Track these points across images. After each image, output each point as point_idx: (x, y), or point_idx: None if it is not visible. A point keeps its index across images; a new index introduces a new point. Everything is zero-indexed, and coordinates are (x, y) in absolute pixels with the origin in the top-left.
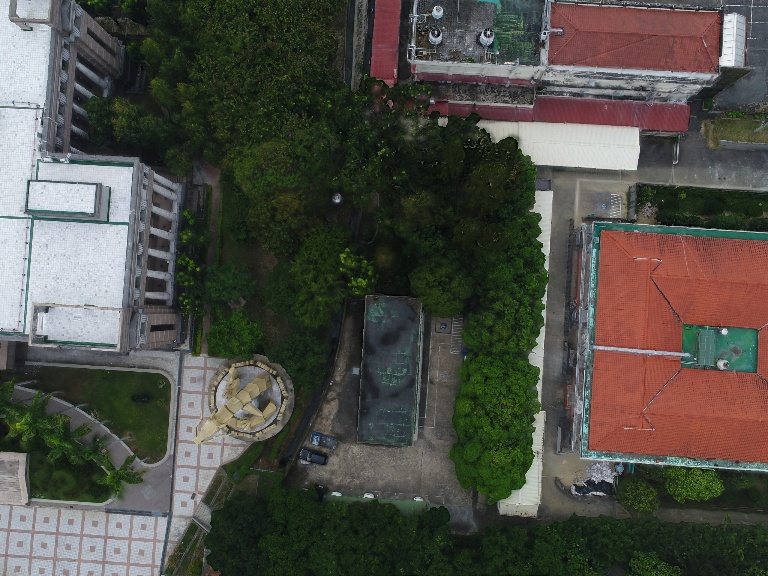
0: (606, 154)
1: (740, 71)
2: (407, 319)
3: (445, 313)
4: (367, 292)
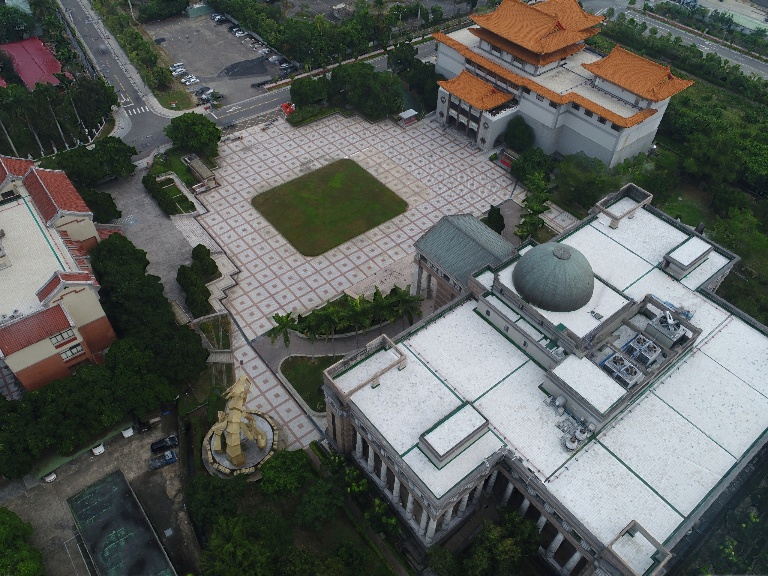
0: None
1: None
2: None
3: None
4: None
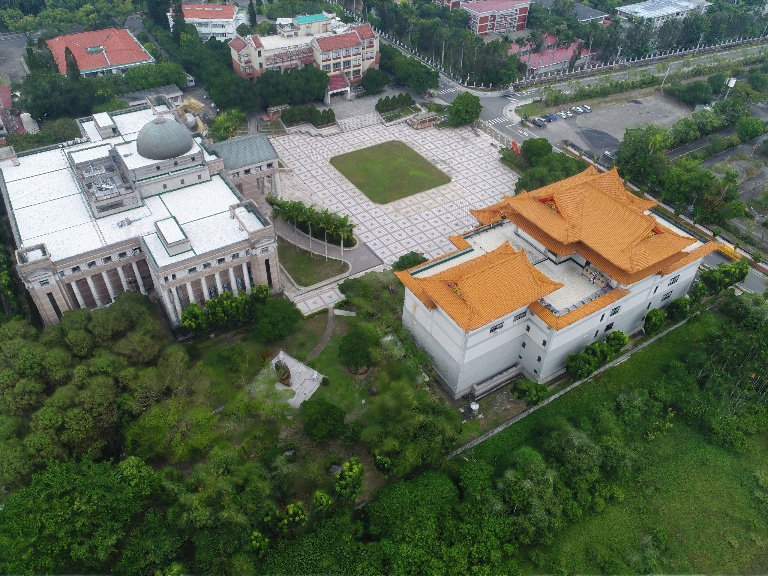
0: None
1: None
2: None
3: None
4: None
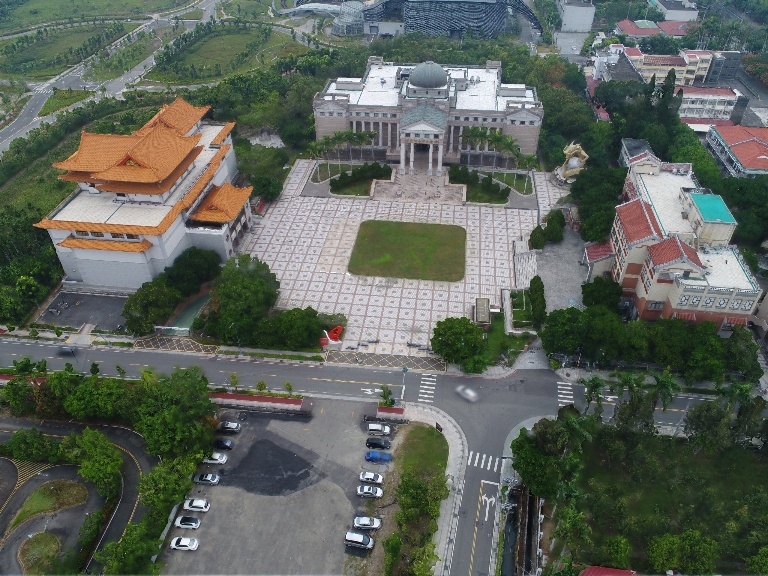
0: (704, 127)
1: (746, 100)
2: (642, 144)
3: (658, 145)
4: (622, 136)
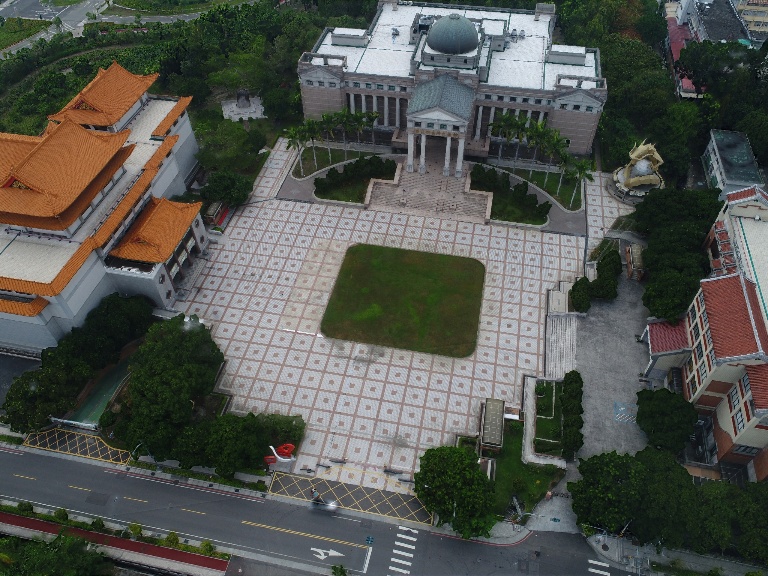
0: None
1: None
2: (739, 140)
3: (761, 142)
4: (713, 126)
